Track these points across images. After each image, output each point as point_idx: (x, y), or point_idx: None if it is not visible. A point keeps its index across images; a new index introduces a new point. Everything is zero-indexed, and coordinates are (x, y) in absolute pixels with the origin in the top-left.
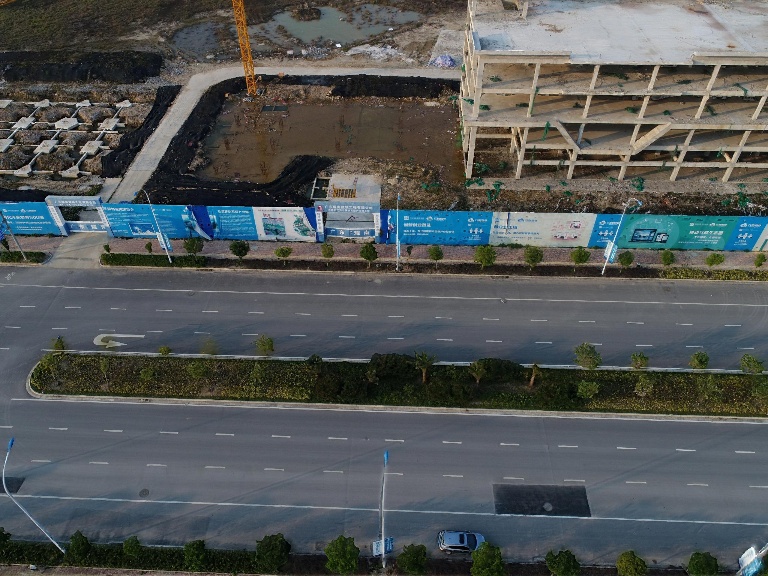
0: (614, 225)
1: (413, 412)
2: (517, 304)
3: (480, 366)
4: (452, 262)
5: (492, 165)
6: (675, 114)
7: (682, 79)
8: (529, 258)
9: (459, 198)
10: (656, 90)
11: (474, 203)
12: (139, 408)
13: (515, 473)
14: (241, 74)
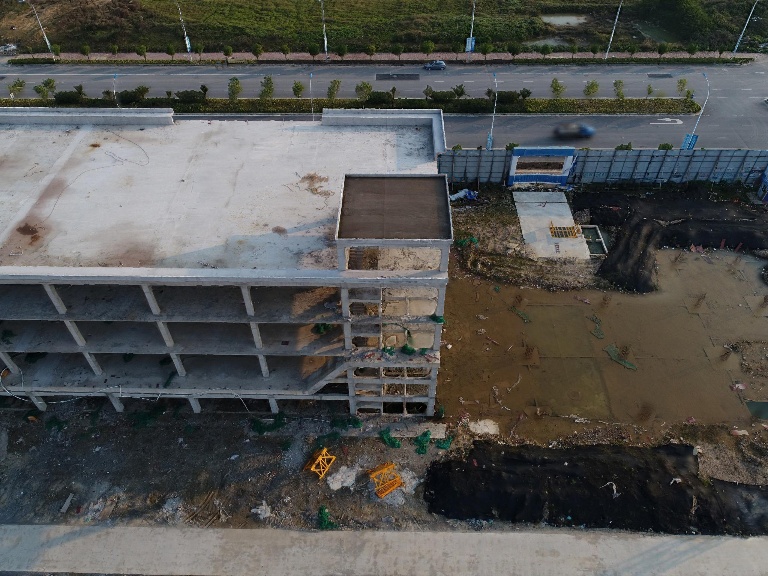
0: None
1: (462, 98)
2: None
3: (426, 92)
4: None
5: None
6: None
7: None
8: None
9: None
10: None
11: None
12: None
13: (409, 83)
14: None
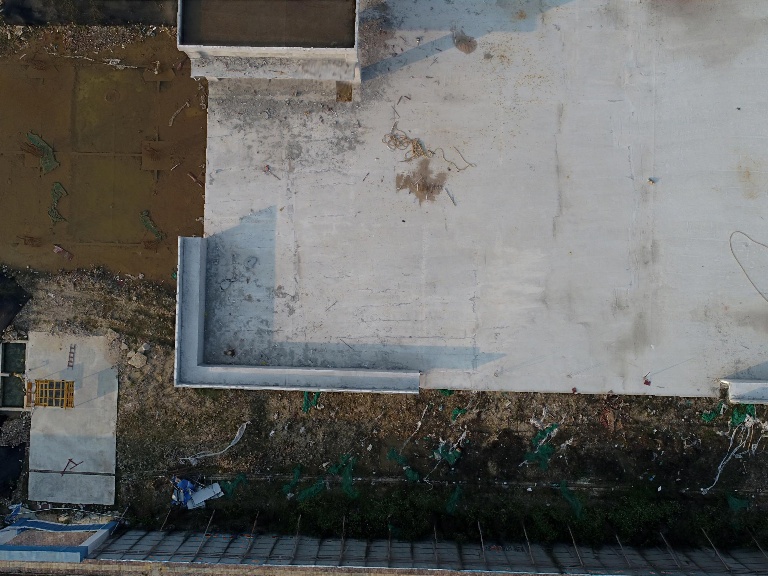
0: None
1: None
2: None
3: None
4: (228, 575)
5: None
6: None
7: None
8: None
9: (251, 411)
10: None
11: (278, 418)
12: None
13: None
14: None
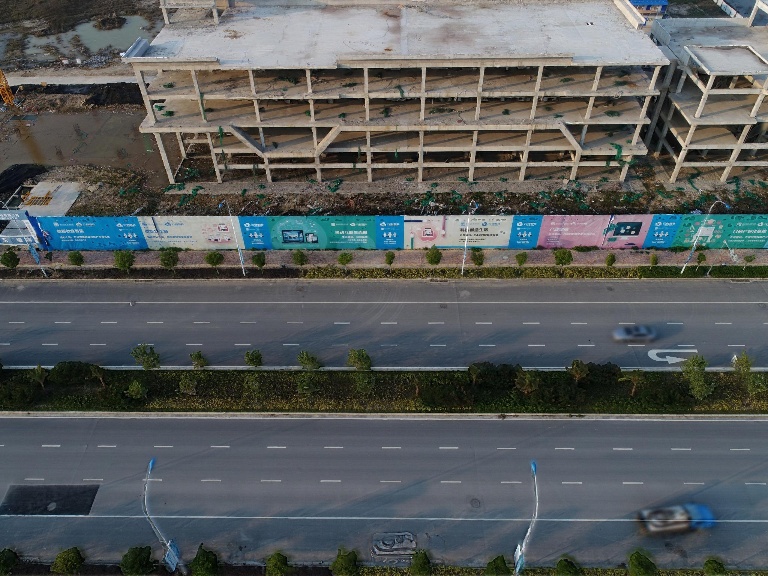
0: (259, 227)
1: None
2: (143, 307)
3: (42, 369)
4: (104, 267)
5: (203, 170)
6: (350, 116)
7: (350, 82)
8: (161, 261)
9: (148, 203)
10: (316, 93)
11: (163, 208)
12: None
13: (39, 474)
14: (8, 84)
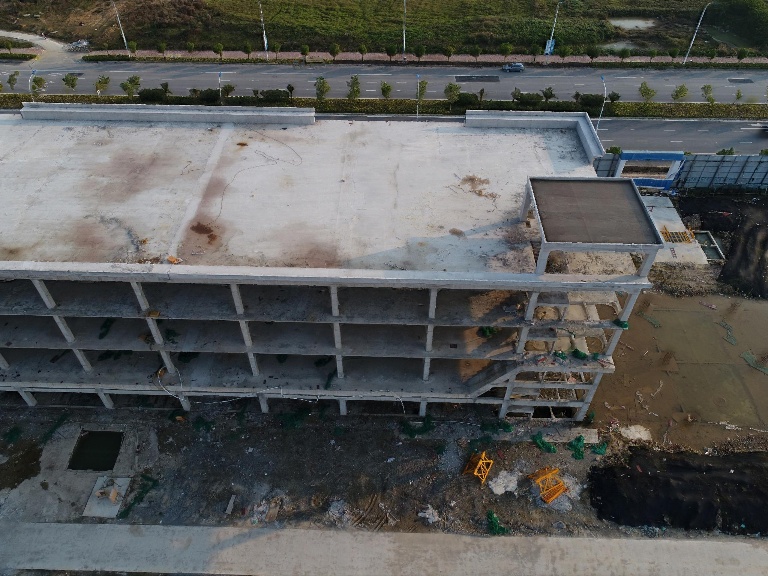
0: None
1: None
2: None
3: (515, 94)
4: None
5: None
6: None
7: None
8: None
9: None
10: None
11: None
12: (703, 101)
13: (490, 85)
14: None
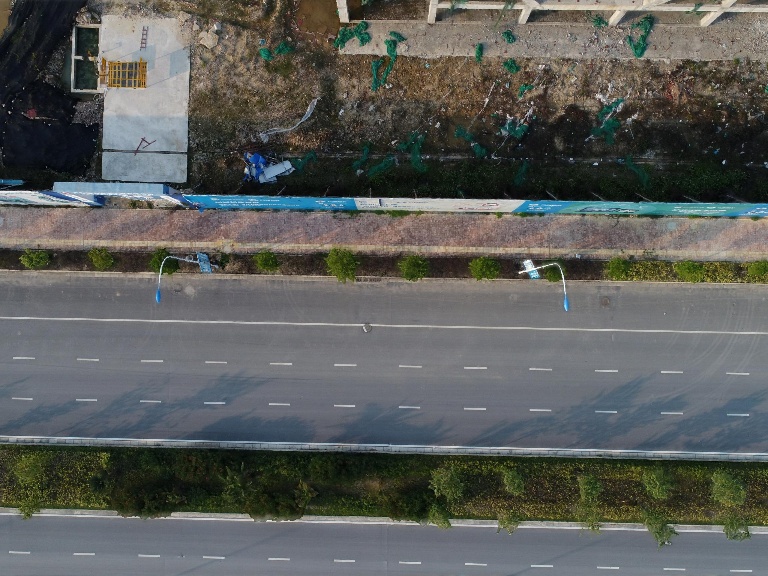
0: (553, 206)
1: (235, 520)
2: (385, 336)
3: (310, 489)
4: (300, 249)
5: None
6: None
7: None
8: None
9: (322, 87)
10: None
11: (347, 96)
12: None
13: None
14: None
